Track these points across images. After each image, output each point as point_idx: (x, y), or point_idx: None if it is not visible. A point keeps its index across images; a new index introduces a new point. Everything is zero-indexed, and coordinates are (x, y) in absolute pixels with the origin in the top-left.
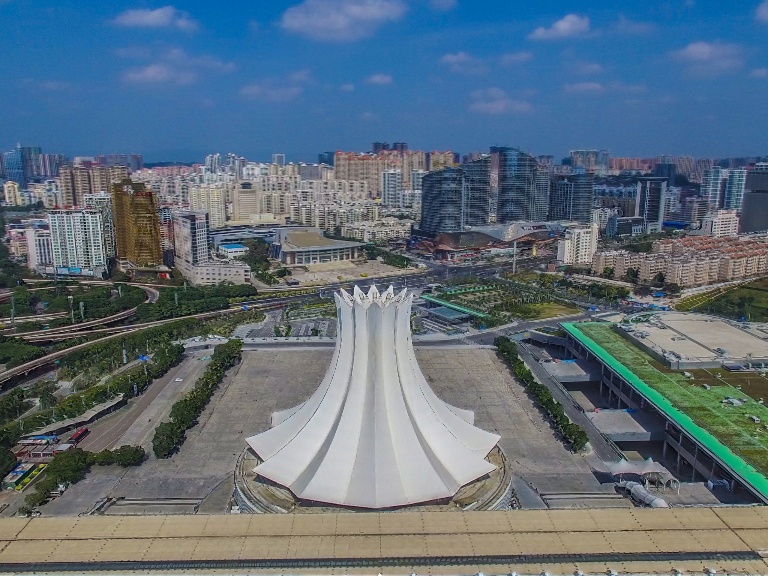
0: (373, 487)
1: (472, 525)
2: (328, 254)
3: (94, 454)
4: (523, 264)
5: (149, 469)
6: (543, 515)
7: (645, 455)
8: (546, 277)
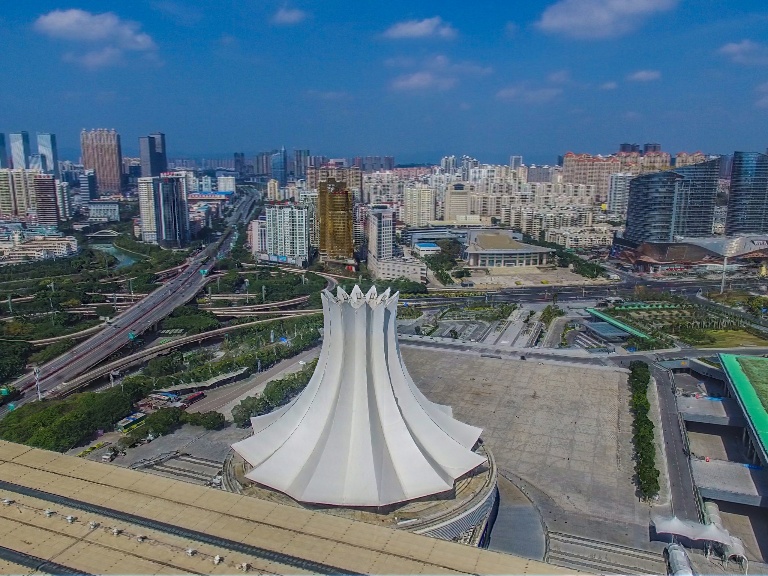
0: (308, 481)
1: (349, 535)
2: (513, 258)
3: (188, 414)
4: (739, 284)
5: (224, 435)
6: (429, 543)
7: (756, 523)
8: (755, 301)
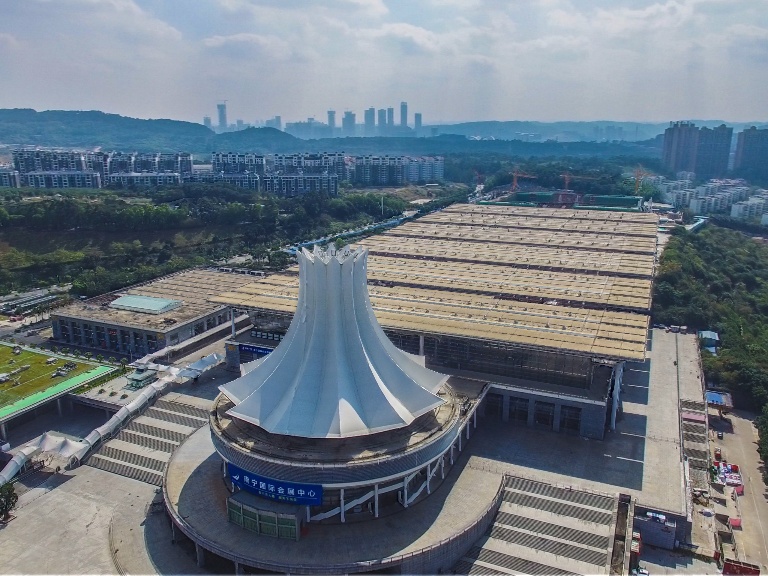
0: None
1: None
2: None
3: None
4: None
5: None
6: None
7: None
8: None
